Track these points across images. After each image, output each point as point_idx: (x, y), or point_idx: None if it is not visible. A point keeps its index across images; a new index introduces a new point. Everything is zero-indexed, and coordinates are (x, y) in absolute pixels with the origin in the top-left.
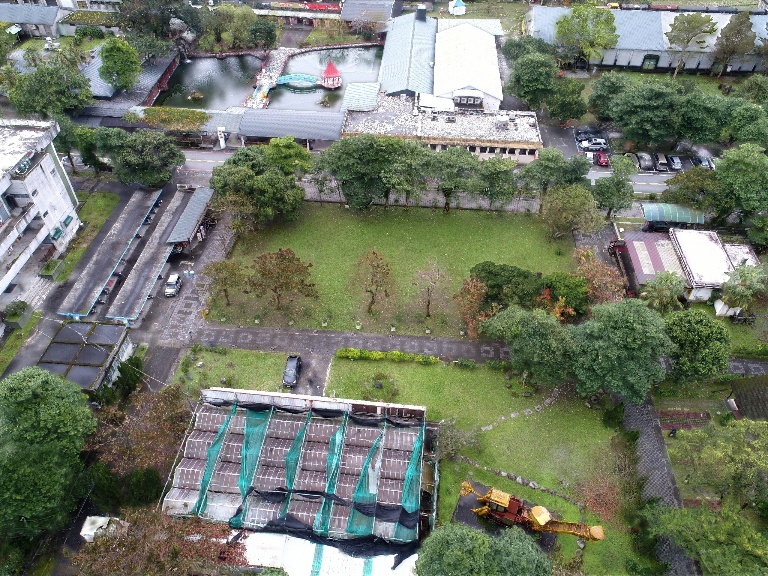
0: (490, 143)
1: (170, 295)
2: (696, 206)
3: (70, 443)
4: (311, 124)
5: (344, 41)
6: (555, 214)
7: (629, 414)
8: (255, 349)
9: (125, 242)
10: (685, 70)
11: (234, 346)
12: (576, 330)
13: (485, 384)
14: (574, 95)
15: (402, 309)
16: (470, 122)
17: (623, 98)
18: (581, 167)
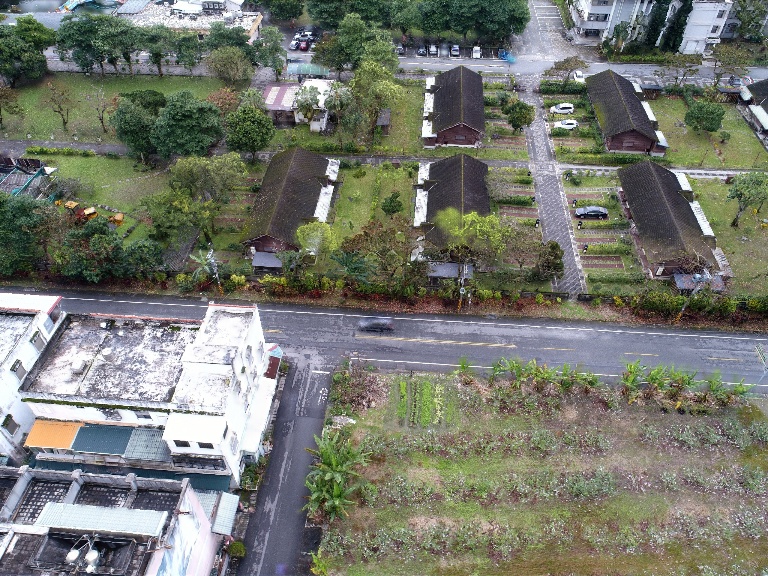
0: None
1: None
2: (324, 63)
3: None
4: None
5: None
6: None
7: None
8: None
9: None
10: None
11: None
12: None
13: (120, 166)
14: None
15: (90, 129)
16: (207, 20)
17: None
18: (243, 36)
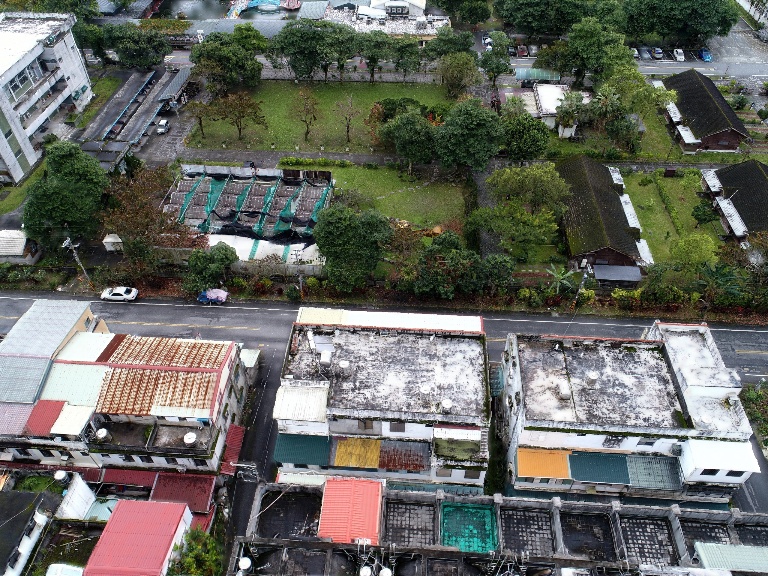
0: (410, 37)
1: (161, 133)
2: (554, 67)
3: (94, 188)
4: (271, 27)
5: None
6: (445, 72)
7: (482, 190)
8: (222, 161)
9: (127, 101)
10: None
11: (207, 160)
12: (440, 127)
13: (384, 176)
14: (479, 2)
15: (330, 138)
16: (397, 25)
17: None
18: (468, 41)
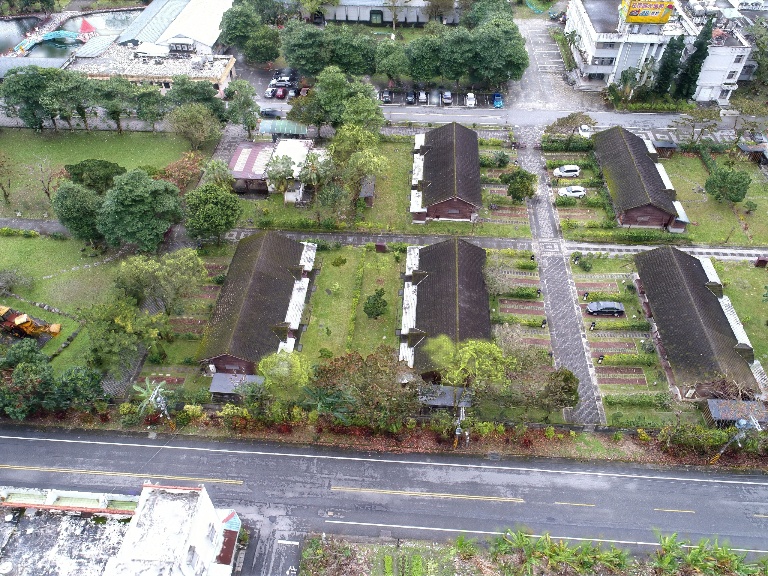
0: None
1: None
2: (300, 120)
3: None
4: None
5: (124, 5)
6: None
7: None
8: None
9: None
10: (408, 24)
11: None
12: None
13: (66, 249)
14: (263, 40)
15: (36, 201)
16: (174, 64)
17: (287, 39)
18: (210, 90)
